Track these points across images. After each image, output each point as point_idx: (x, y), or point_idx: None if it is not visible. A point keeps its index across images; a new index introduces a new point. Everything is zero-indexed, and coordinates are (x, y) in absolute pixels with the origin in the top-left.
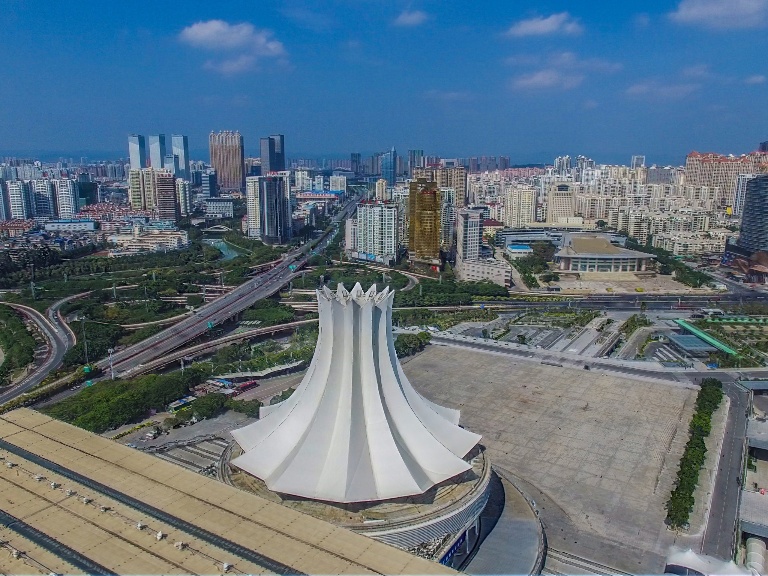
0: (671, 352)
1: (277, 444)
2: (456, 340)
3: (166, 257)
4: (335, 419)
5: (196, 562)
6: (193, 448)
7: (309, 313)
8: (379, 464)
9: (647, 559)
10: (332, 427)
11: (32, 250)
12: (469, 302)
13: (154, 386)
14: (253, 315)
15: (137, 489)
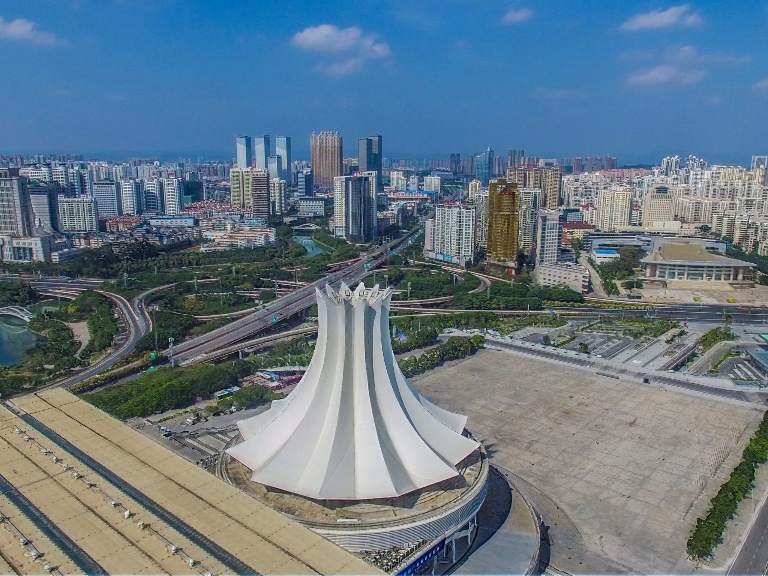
0: (751, 369)
1: (271, 437)
2: (513, 345)
3: (253, 253)
4: (325, 416)
5: (151, 542)
6: (223, 436)
7: None
8: (362, 464)
9: None
10: (322, 424)
11: (132, 243)
12: (539, 307)
13: (203, 375)
14: None
15: (126, 469)
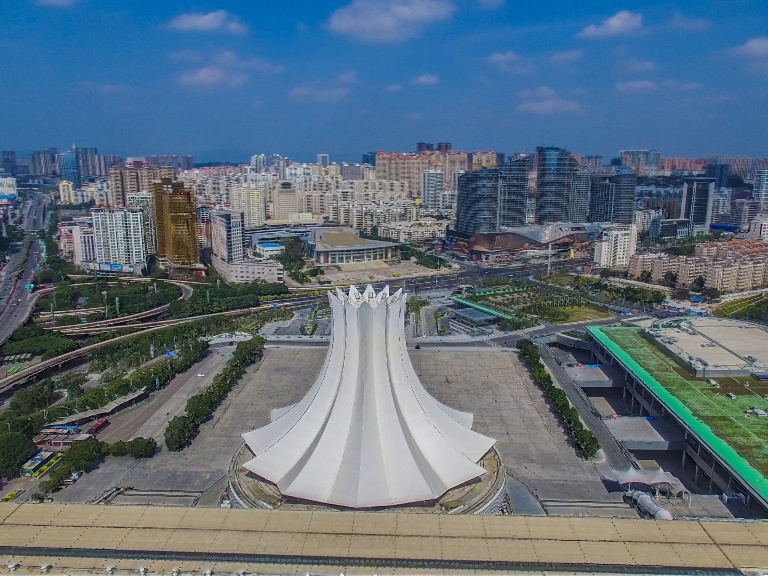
0: (460, 325)
1: (322, 463)
2: (282, 341)
3: None
4: (377, 424)
5: None
6: None
7: (93, 336)
8: (431, 457)
9: (591, 487)
10: (377, 432)
11: None
12: (258, 303)
13: None
14: (19, 348)
15: (246, 545)
